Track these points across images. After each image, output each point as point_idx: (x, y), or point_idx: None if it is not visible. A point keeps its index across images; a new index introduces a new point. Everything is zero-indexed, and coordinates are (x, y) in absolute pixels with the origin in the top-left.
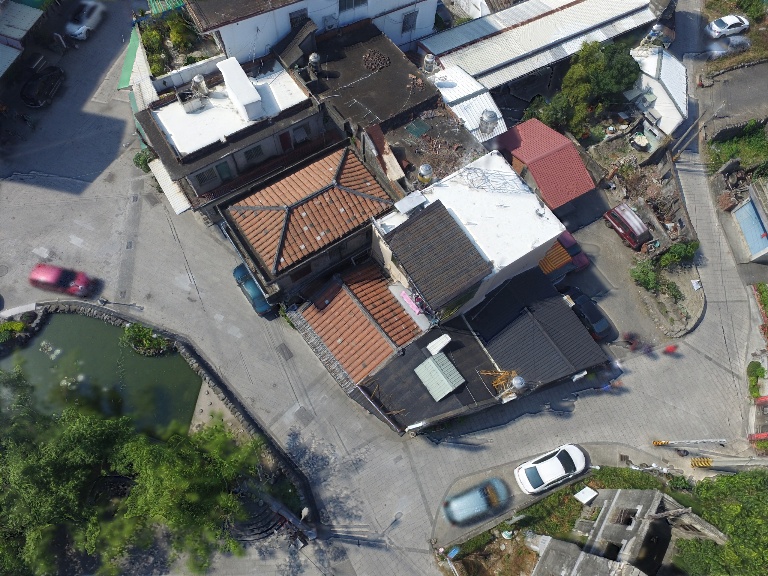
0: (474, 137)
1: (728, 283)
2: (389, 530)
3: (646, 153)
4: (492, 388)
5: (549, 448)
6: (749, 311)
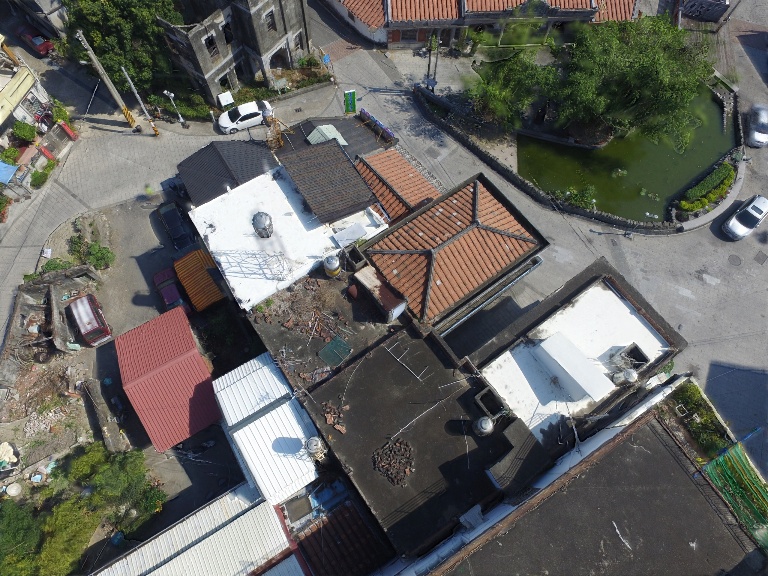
0: (264, 341)
1: (7, 265)
2: (366, 93)
3: (5, 441)
4: (285, 140)
5: (243, 133)
6: (4, 237)
